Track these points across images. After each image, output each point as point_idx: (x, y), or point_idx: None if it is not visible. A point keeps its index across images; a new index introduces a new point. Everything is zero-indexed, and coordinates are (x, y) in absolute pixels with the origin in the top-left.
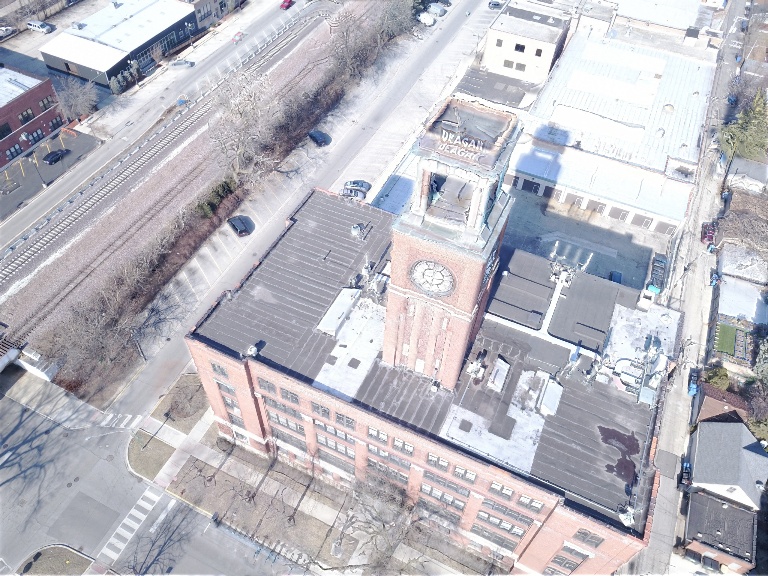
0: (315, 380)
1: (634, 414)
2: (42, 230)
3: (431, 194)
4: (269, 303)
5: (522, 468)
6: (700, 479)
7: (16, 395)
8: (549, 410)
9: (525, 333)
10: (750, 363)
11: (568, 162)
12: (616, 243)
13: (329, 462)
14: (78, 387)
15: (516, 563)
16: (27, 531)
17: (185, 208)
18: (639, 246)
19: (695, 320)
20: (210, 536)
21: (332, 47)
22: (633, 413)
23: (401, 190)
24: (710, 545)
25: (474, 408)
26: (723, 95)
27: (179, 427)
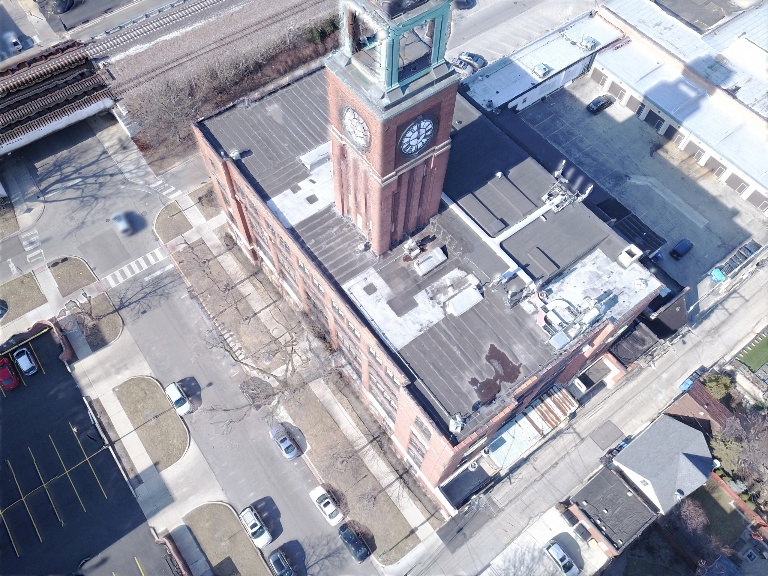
0: (272, 199)
1: (535, 350)
2: (176, 8)
3: (357, 36)
4: (276, 122)
5: (394, 344)
6: (621, 460)
7: (103, 138)
8: (454, 310)
9: (477, 235)
10: (767, 387)
11: (712, 107)
12: (713, 213)
13: (289, 286)
14: (148, 150)
15: (393, 435)
16: (66, 240)
17: (292, 25)
18: (738, 226)
19: (746, 324)
20: (184, 303)
21: None
22: (535, 349)
23: (505, 76)
24: (588, 516)
25: (388, 279)
26: None
27: (204, 212)
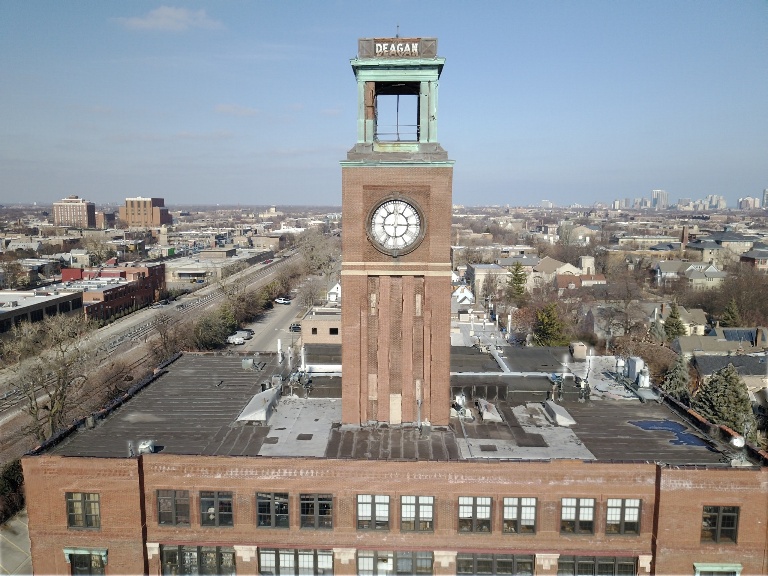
0: None
1: (650, 409)
2: None
3: (375, 118)
4: (154, 421)
5: None
6: None
7: None
8: (567, 420)
9: (491, 375)
10: None
11: None
12: None
13: None
14: None
15: None
16: None
17: None
18: None
19: None
20: None
21: (150, 346)
22: (648, 409)
23: None
24: None
25: (485, 435)
26: (512, 329)
27: None
